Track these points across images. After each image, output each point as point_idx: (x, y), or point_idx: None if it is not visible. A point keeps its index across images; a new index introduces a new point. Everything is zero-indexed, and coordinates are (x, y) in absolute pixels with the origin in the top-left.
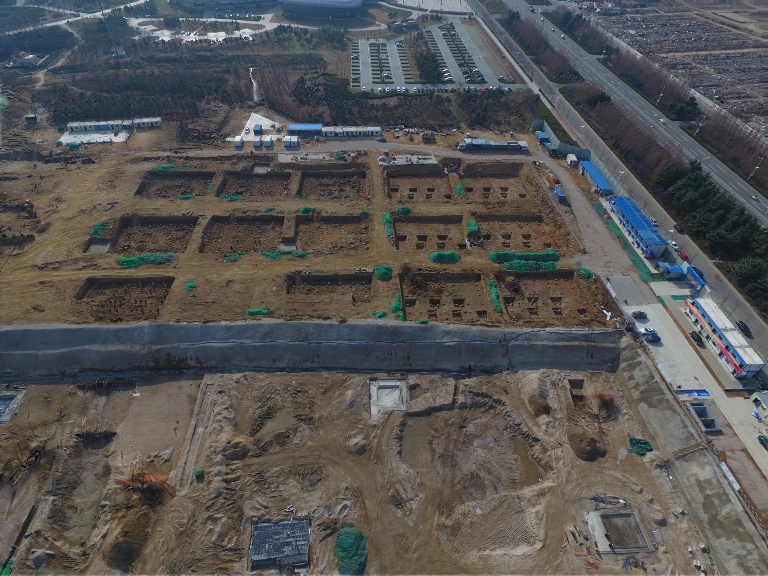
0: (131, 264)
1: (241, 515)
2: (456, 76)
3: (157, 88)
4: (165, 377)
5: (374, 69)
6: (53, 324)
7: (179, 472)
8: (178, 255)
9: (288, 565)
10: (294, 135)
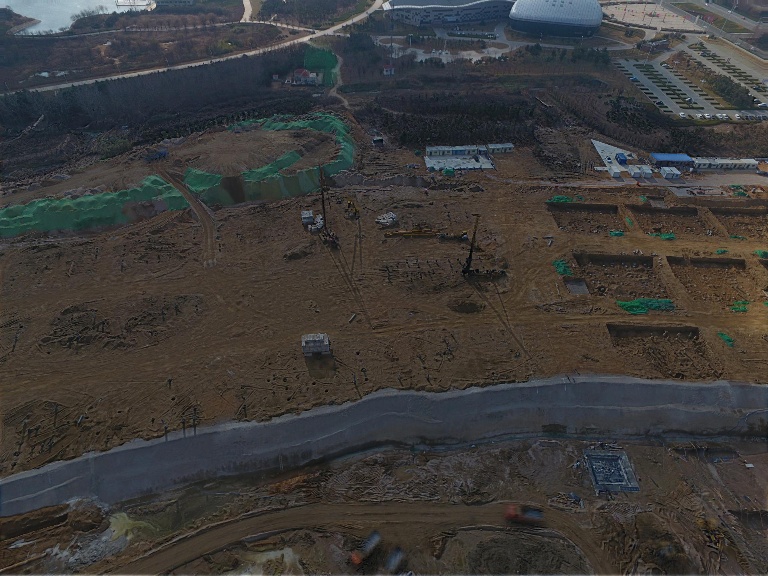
0: (638, 310)
1: None
2: (765, 102)
3: (477, 111)
4: (762, 445)
5: (668, 93)
6: (625, 378)
7: None
8: (676, 301)
9: None
10: (662, 166)
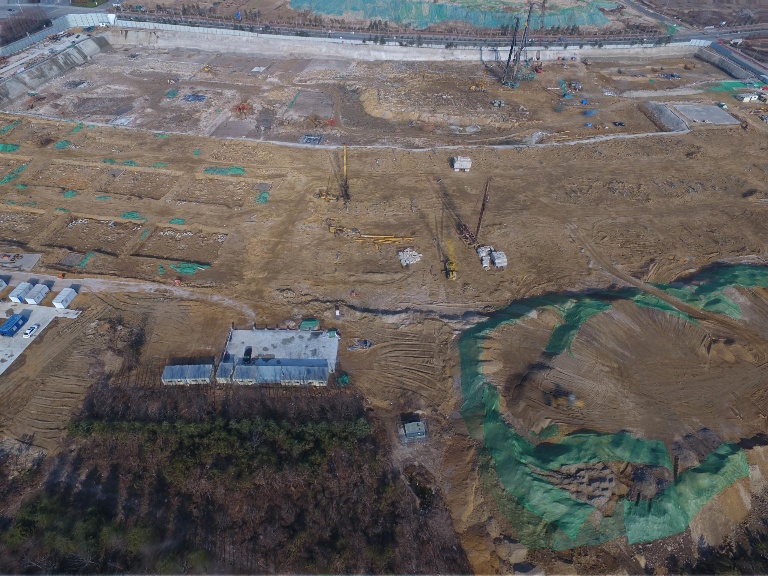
0: None
1: (206, 103)
2: None
3: None
4: None
5: None
6: (282, 143)
7: (227, 114)
8: (200, 171)
9: (194, 95)
10: None
